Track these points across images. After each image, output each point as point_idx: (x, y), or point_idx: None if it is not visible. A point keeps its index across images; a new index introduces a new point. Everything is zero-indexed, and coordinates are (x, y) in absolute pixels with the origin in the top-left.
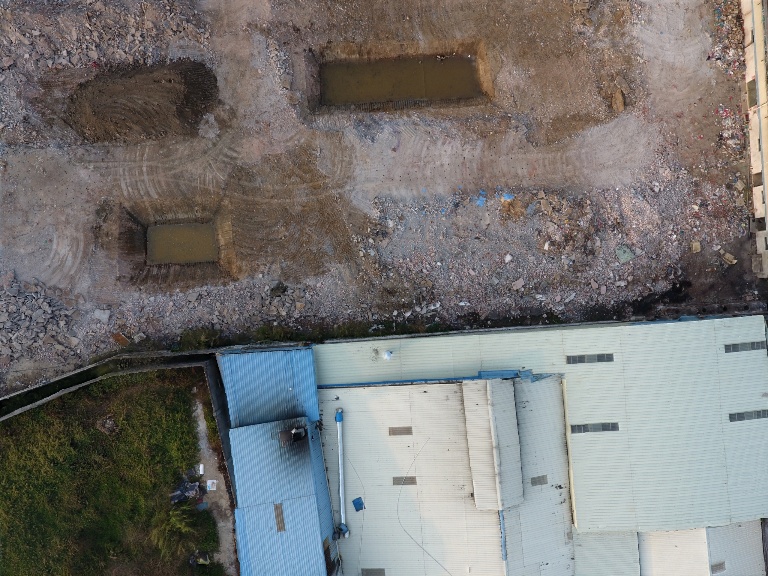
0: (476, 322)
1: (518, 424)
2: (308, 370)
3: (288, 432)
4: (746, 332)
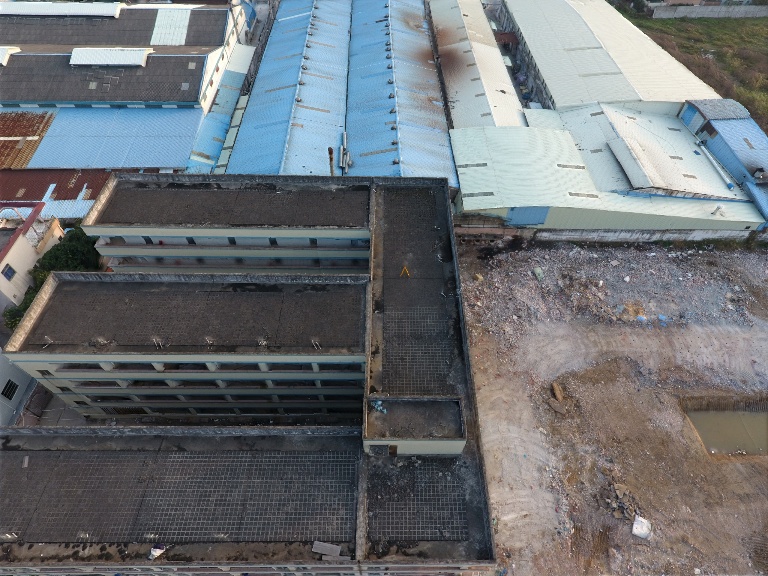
0: (636, 246)
1: (621, 171)
2: (765, 207)
3: (765, 177)
4: (478, 201)
